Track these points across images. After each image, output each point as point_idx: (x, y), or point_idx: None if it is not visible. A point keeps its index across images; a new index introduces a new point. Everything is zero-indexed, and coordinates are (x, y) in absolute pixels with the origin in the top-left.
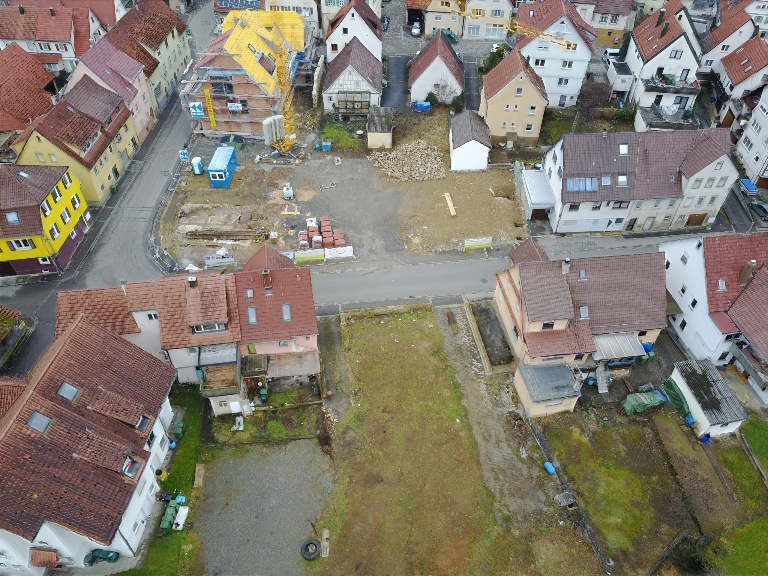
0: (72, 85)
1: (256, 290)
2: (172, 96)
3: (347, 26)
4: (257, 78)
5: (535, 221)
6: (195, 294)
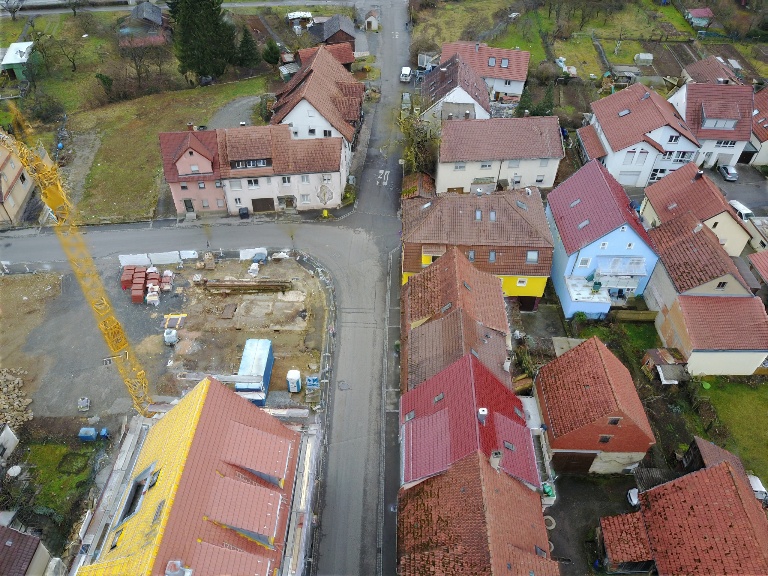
0: None
1: None
2: None
3: None
4: None
5: None
6: None
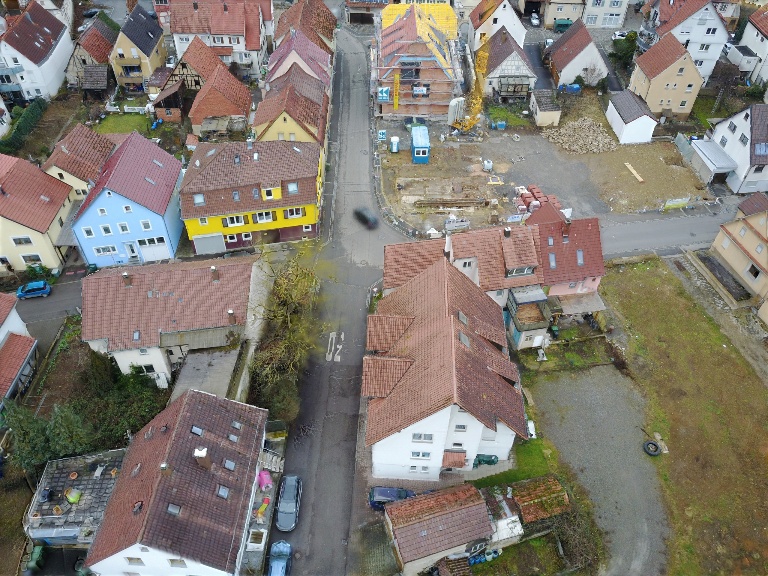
0: (279, 73)
1: (555, 238)
2: (334, 84)
3: (497, 16)
4: (442, 64)
5: (713, 184)
6: (509, 242)
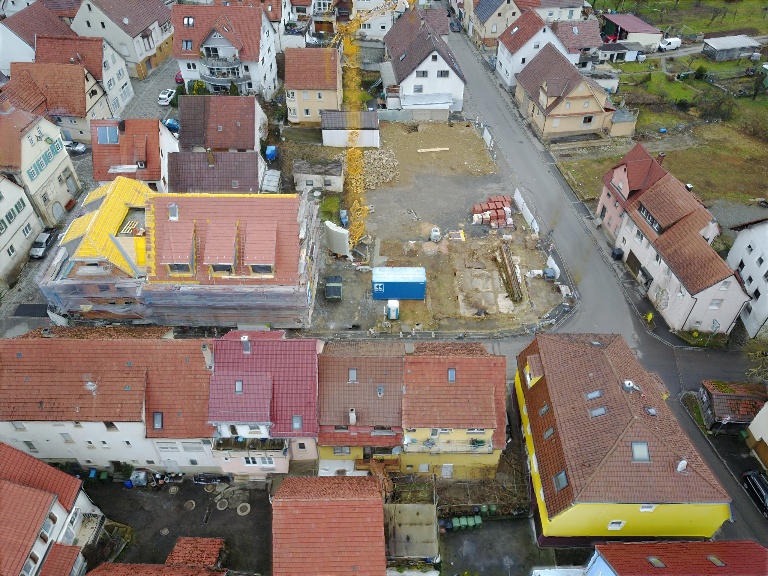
0: None
1: None
2: None
3: (161, 147)
4: None
5: None
6: None
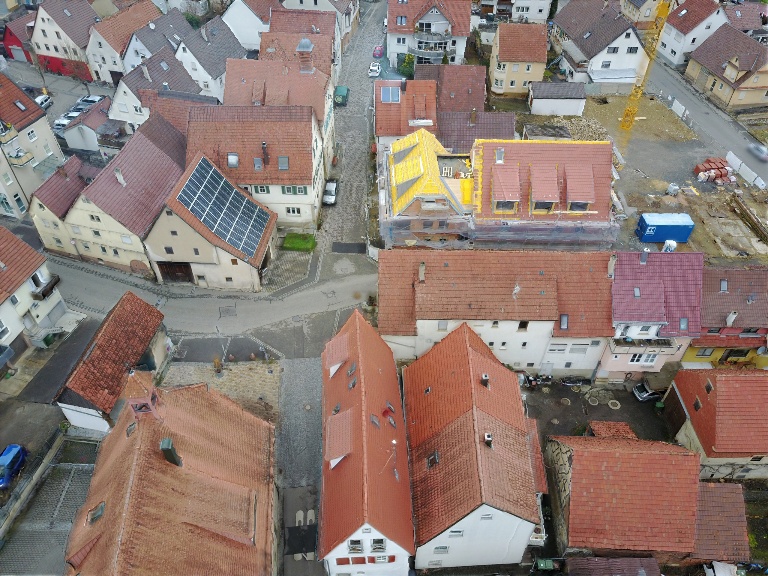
0: None
1: None
2: None
3: None
4: None
5: None
6: None
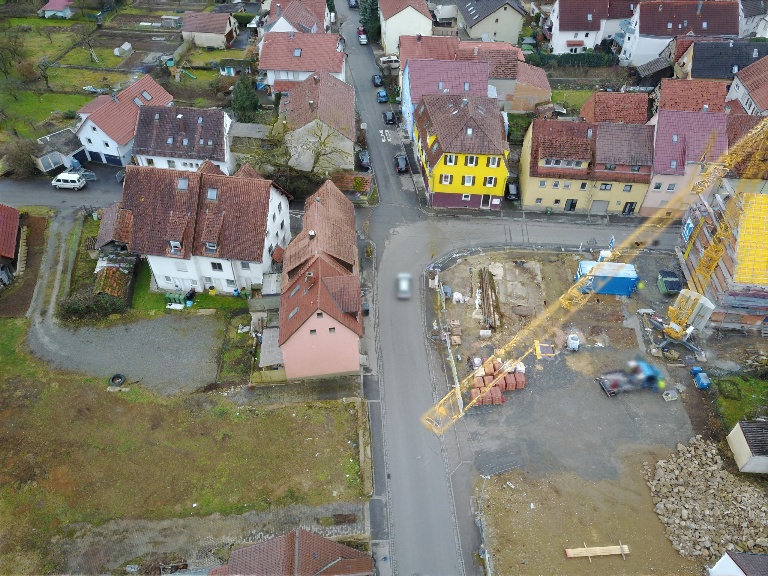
0: None
1: None
2: None
3: None
4: (746, 253)
5: None
6: None
